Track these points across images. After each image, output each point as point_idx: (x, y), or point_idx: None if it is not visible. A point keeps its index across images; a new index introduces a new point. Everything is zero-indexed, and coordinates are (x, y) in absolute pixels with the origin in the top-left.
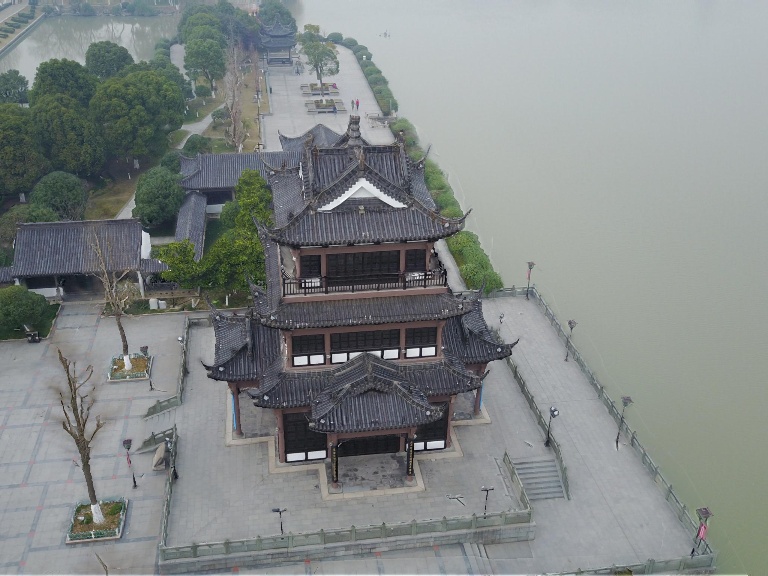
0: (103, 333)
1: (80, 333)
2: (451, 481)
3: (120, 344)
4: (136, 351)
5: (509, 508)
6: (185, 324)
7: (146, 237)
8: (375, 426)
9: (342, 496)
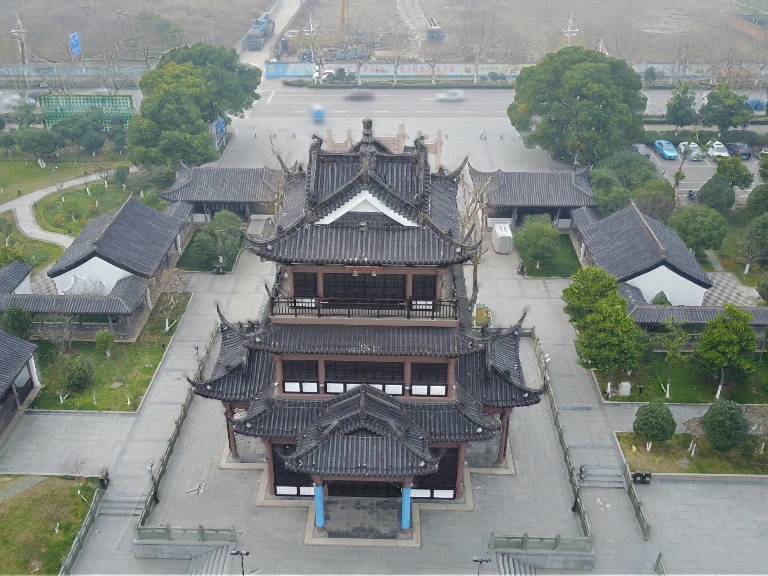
0: (537, 301)
1: (537, 291)
2: (224, 489)
3: (517, 311)
4: (505, 319)
5: (165, 525)
6: (557, 344)
7: (681, 282)
8: (217, 363)
9: (237, 415)
